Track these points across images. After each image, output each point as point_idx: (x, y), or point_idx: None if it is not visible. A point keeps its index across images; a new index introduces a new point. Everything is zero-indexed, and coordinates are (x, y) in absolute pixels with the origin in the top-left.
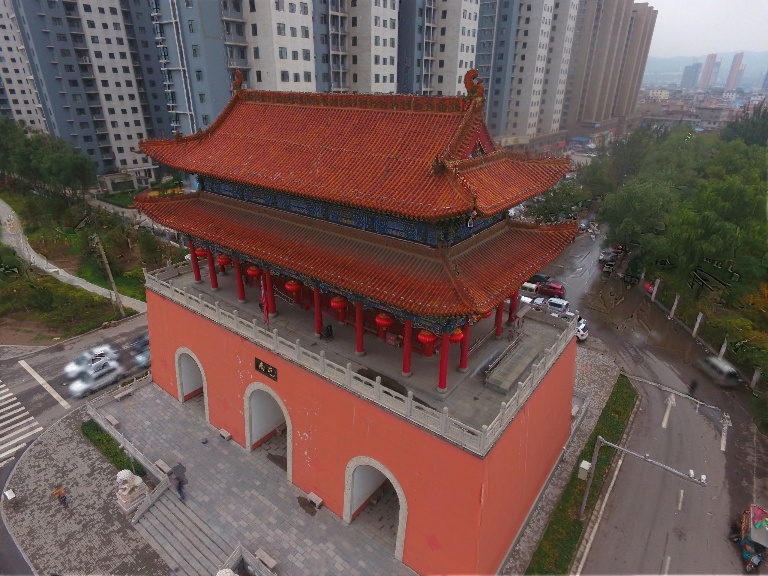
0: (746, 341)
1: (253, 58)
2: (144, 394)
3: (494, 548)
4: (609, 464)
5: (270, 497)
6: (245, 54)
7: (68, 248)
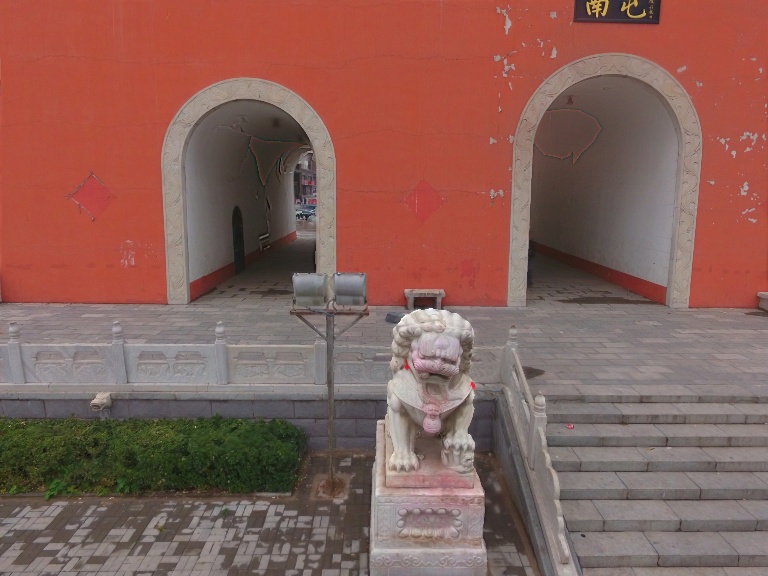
0: None
1: None
2: (7, 317)
3: None
4: None
5: (725, 325)
6: None
7: None
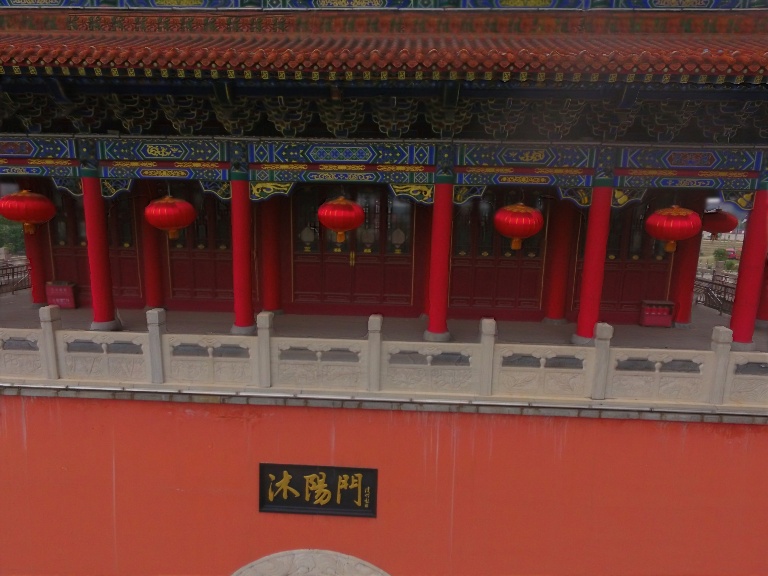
0: None
1: None
2: None
3: None
4: None
5: None
6: None
7: None
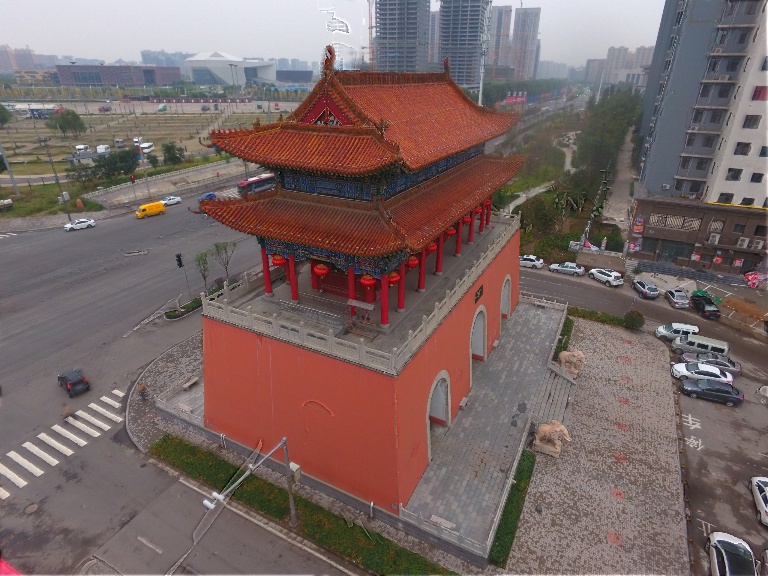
0: (372, 533)
1: (752, 42)
2: None
3: (230, 417)
4: (369, 567)
5: None
6: (747, 37)
7: (502, 198)
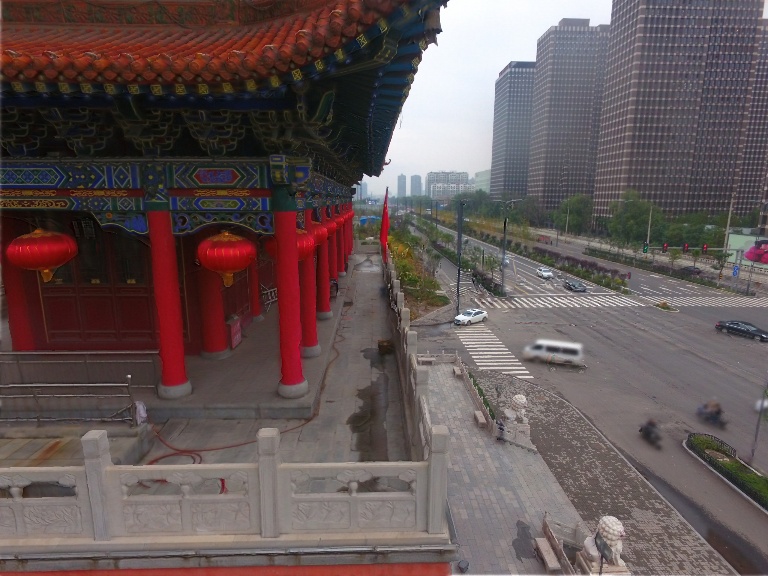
0: None
1: None
2: None
3: None
4: None
5: None
6: None
7: None
